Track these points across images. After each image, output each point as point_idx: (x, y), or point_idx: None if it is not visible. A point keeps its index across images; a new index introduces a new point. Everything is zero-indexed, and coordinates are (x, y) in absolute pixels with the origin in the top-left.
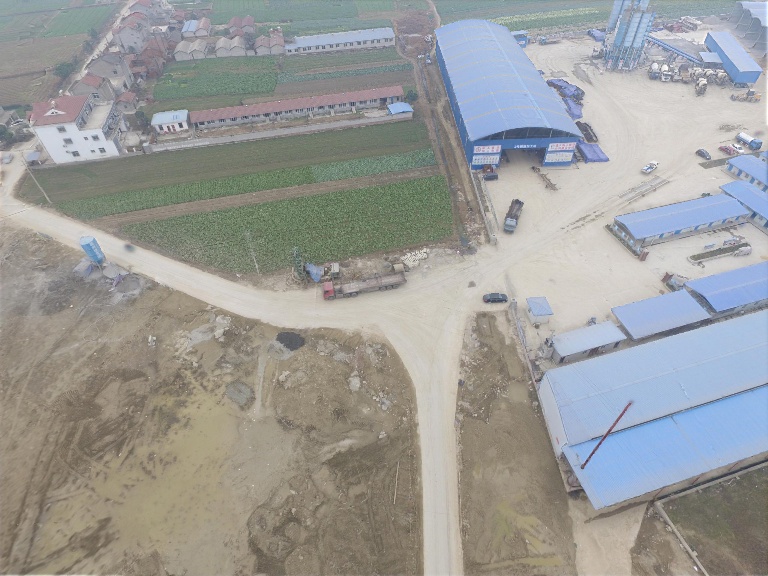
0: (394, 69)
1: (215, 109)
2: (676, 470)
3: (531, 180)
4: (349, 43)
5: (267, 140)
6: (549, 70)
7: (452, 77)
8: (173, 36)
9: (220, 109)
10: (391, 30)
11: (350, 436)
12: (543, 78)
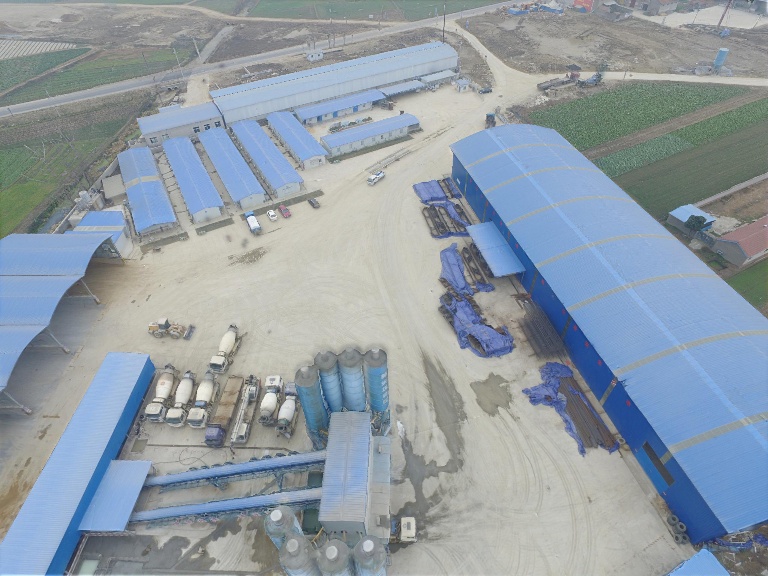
0: None
1: None
2: (413, 47)
3: None
4: None
5: None
6: (519, 413)
7: None
8: None
9: None
10: None
11: (523, 57)
12: None
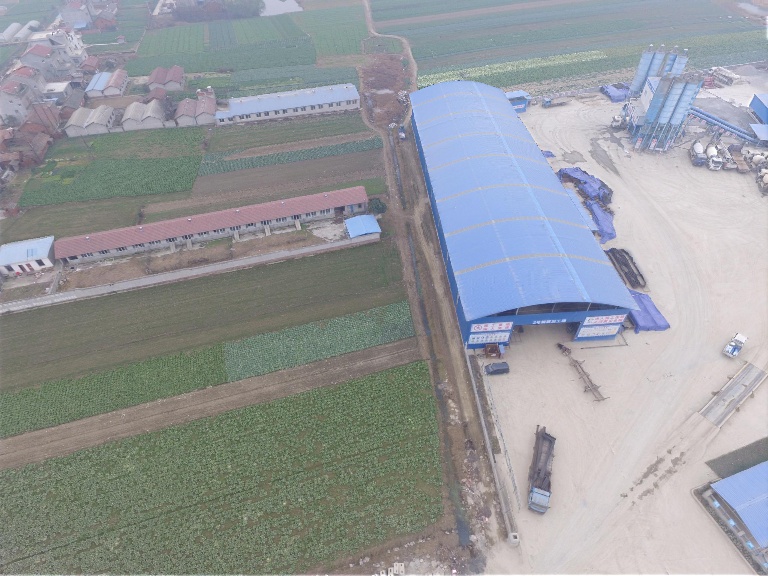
0: (357, 148)
1: (93, 235)
2: None
3: (559, 373)
4: (300, 108)
5: (166, 287)
6: (559, 150)
7: (434, 181)
8: (70, 99)
9: (101, 235)
10: (354, 89)
11: None
12: (554, 166)
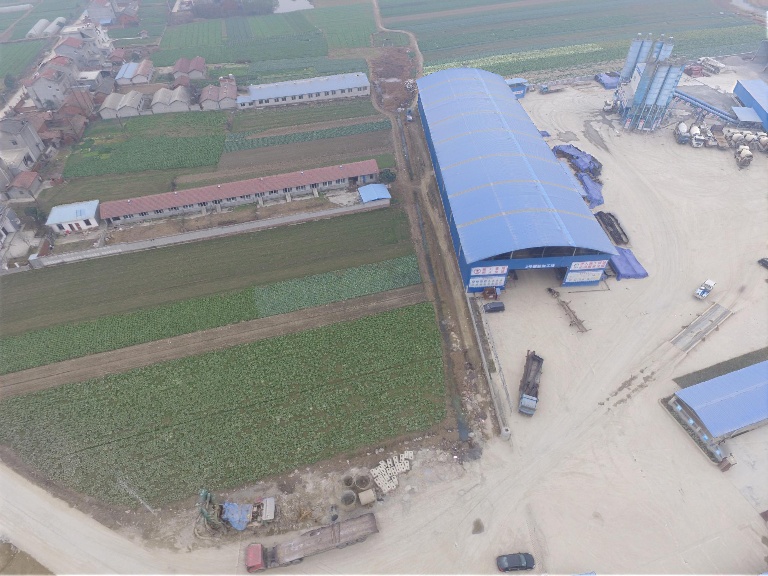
0: (368, 129)
1: (134, 199)
2: None
3: (549, 311)
4: (315, 94)
5: (200, 243)
6: (555, 130)
7: (439, 152)
8: (103, 86)
9: (141, 199)
10: (365, 77)
11: None
12: (549, 144)
